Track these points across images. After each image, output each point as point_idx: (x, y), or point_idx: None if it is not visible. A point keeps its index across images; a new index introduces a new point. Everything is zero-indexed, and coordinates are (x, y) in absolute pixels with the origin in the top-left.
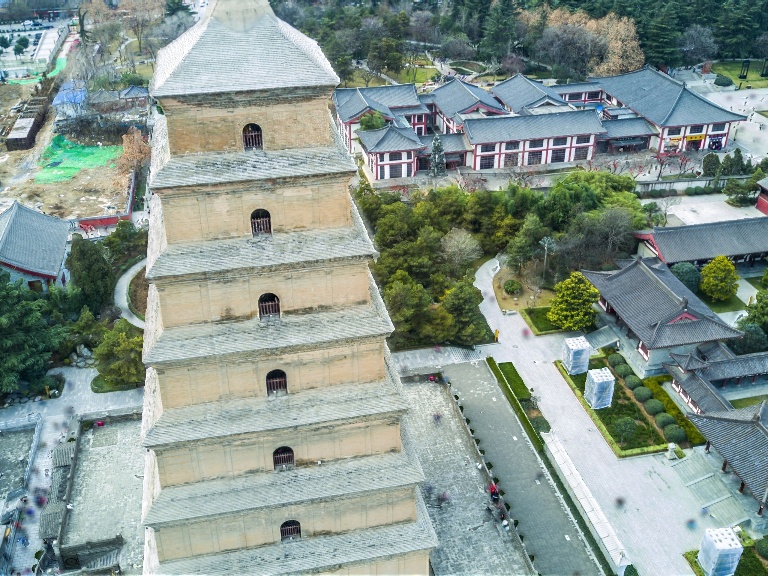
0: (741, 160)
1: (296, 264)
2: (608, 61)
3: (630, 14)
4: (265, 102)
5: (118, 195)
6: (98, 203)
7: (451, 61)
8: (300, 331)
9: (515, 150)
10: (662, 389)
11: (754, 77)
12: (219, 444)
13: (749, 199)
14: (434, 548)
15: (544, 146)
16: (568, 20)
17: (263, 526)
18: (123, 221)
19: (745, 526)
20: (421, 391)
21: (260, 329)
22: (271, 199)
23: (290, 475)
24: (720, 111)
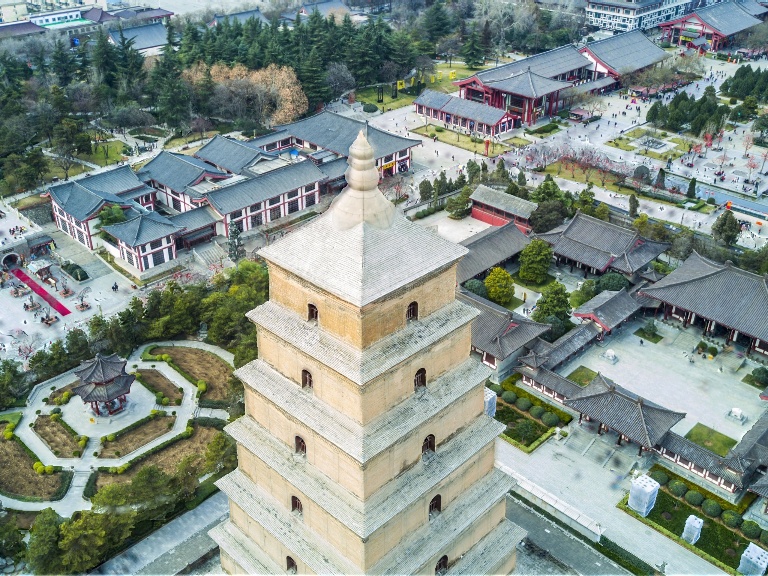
0: (446, 181)
1: None
2: (283, 108)
3: (281, 61)
4: (423, 282)
5: None
6: None
7: (128, 130)
8: (453, 456)
9: (258, 211)
10: (518, 388)
11: (388, 100)
12: None
13: (465, 211)
14: None
15: (281, 201)
16: (229, 74)
17: None
18: None
19: (635, 468)
20: None
21: (427, 468)
22: (427, 358)
23: None
24: (400, 140)
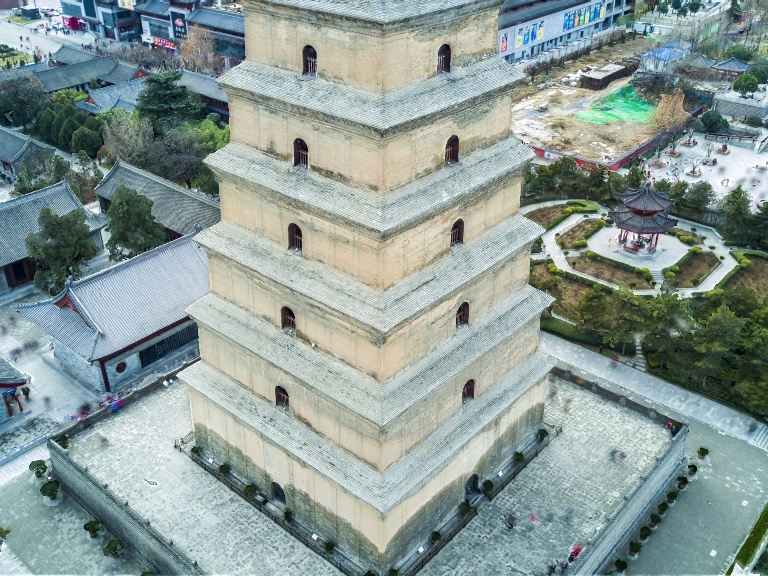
0: None
1: (318, 114)
2: None
3: None
4: None
5: (627, 150)
6: (603, 150)
7: None
8: (312, 190)
9: None
10: None
11: None
12: (245, 273)
13: None
14: (382, 513)
15: None
16: None
17: (263, 377)
18: (567, 157)
19: None
20: (644, 428)
21: (287, 173)
22: (318, 37)
23: (290, 341)
24: None
